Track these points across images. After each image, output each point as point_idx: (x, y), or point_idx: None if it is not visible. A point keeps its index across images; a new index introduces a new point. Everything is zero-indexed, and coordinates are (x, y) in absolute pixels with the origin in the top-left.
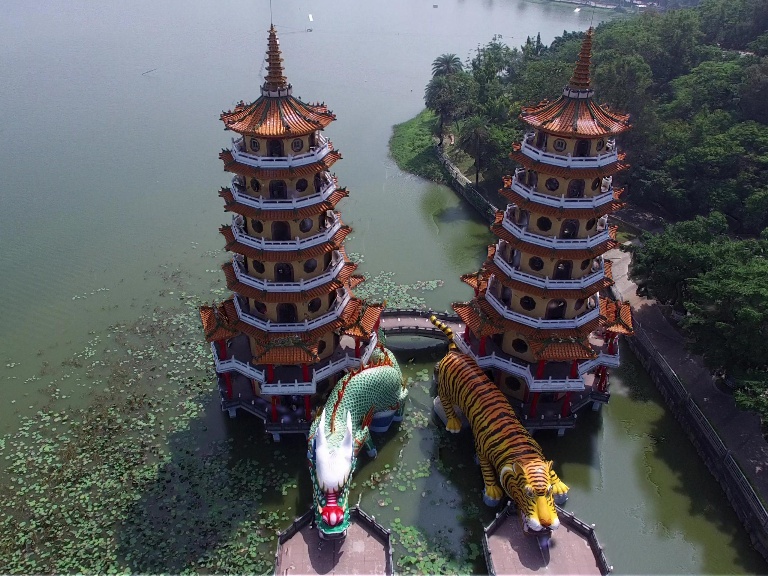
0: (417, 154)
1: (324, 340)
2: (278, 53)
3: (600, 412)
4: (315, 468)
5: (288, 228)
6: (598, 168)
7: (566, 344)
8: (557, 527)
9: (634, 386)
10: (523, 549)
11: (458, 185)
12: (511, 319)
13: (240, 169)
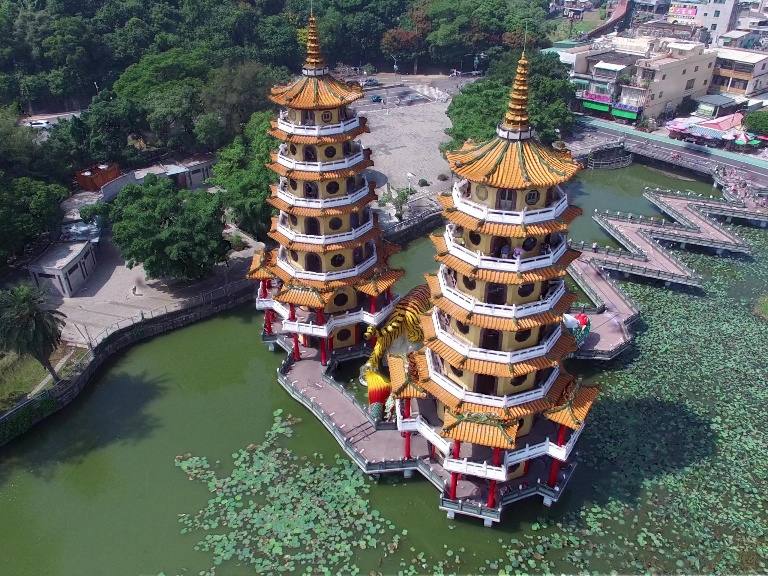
0: None
1: None
2: None
3: None
4: (574, 329)
5: None
6: None
7: None
8: None
9: None
10: None
11: None
12: None
13: None
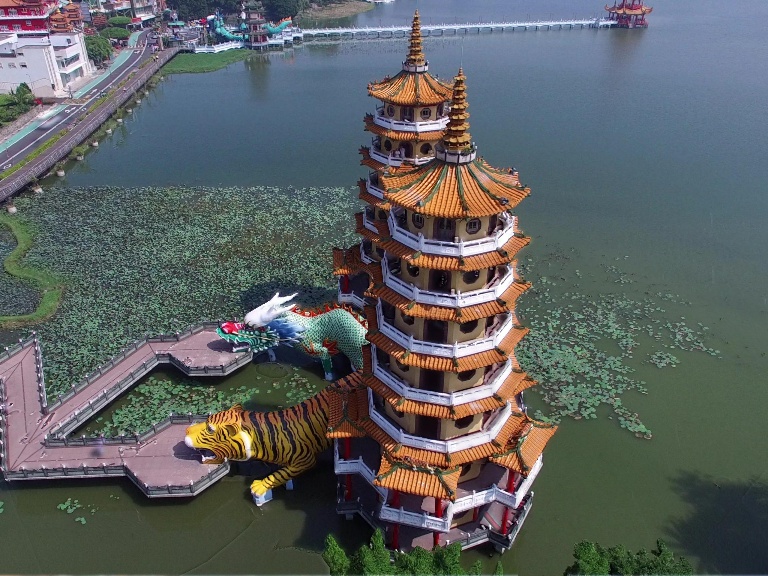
0: None
1: None
2: (415, 35)
3: None
4: None
5: None
6: None
7: None
8: None
9: None
10: None
11: None
12: None
13: None
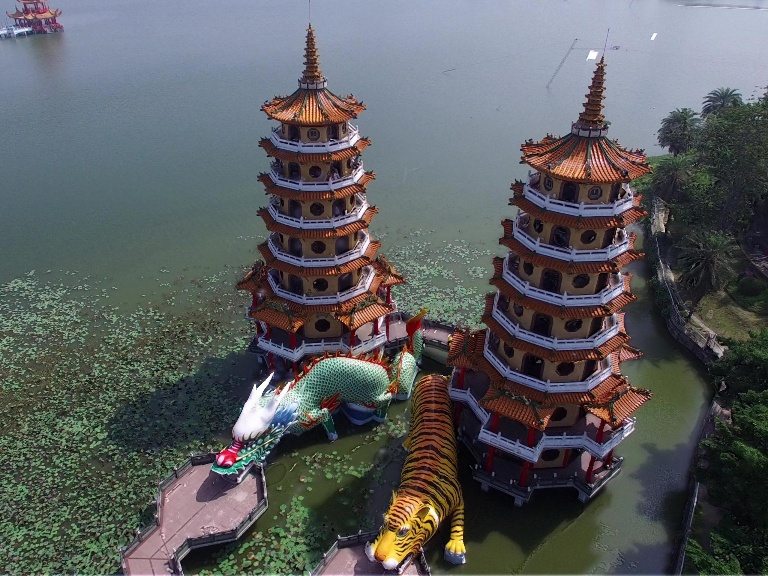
0: (635, 190)
1: (329, 320)
2: (313, 50)
3: (586, 505)
4: None
5: (300, 207)
6: (578, 217)
7: (519, 403)
8: (390, 567)
9: (655, 499)
10: (362, 573)
11: (650, 231)
12: (488, 359)
13: (268, 146)
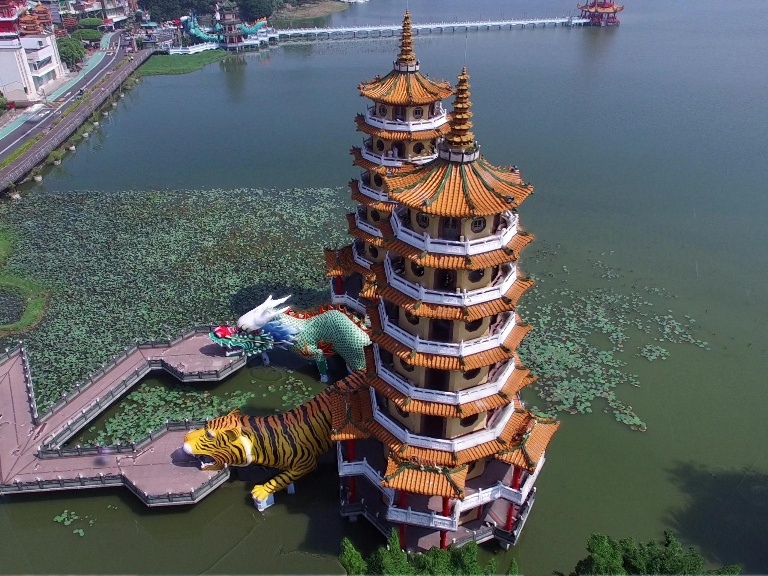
0: None
1: None
2: (406, 34)
3: None
4: None
5: None
6: None
7: None
8: None
9: None
10: None
11: None
12: None
13: None
